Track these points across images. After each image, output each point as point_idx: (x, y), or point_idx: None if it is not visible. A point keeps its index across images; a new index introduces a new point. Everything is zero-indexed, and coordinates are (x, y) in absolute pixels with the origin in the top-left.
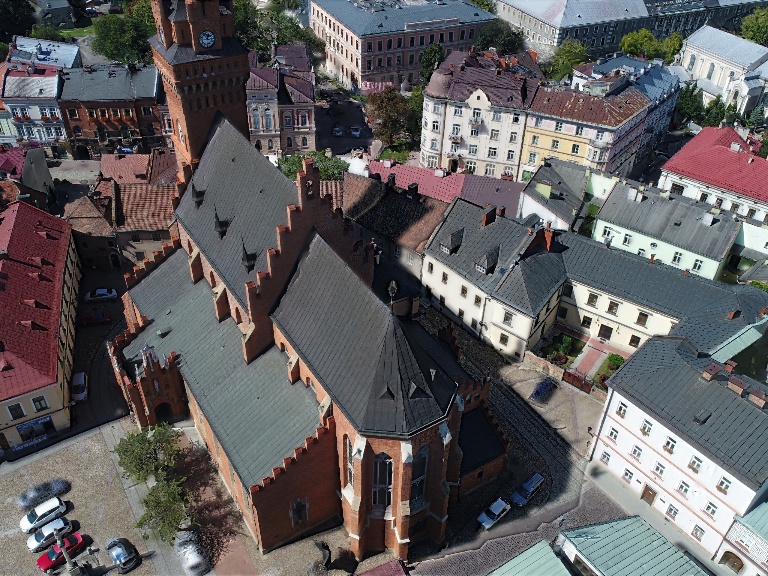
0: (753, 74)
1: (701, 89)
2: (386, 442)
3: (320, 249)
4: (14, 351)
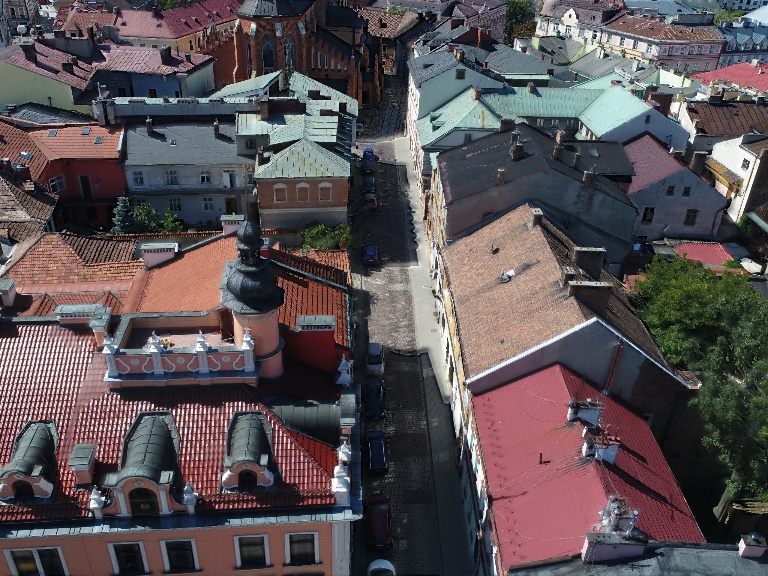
0: None
1: None
2: (247, 23)
3: None
4: (167, 22)
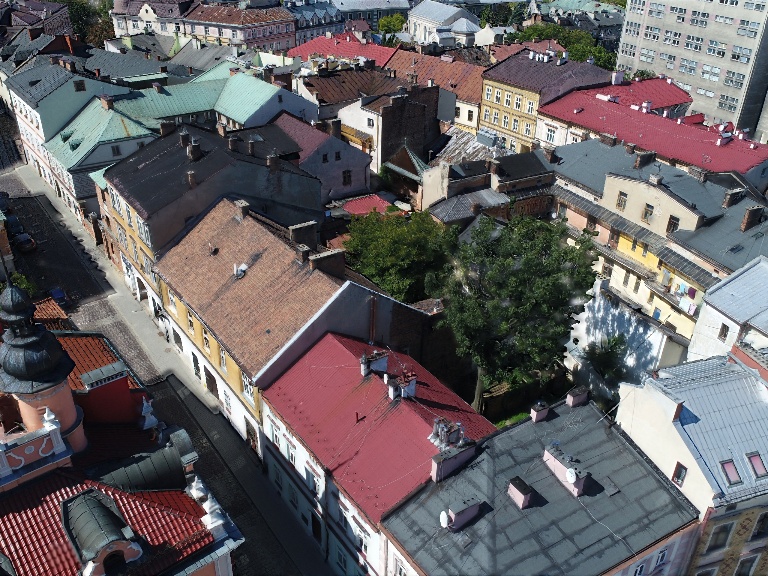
0: (445, 28)
1: (397, 38)
2: None
3: None
4: None
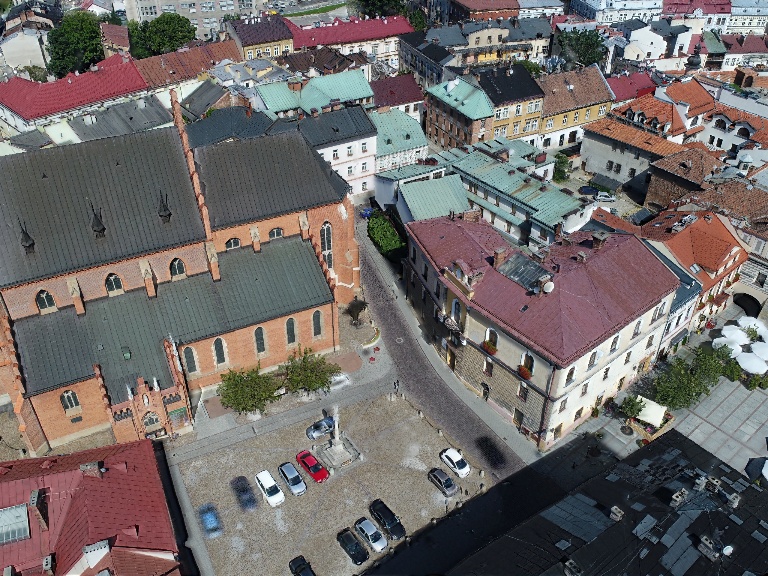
0: None
1: None
2: None
3: (208, 153)
4: None
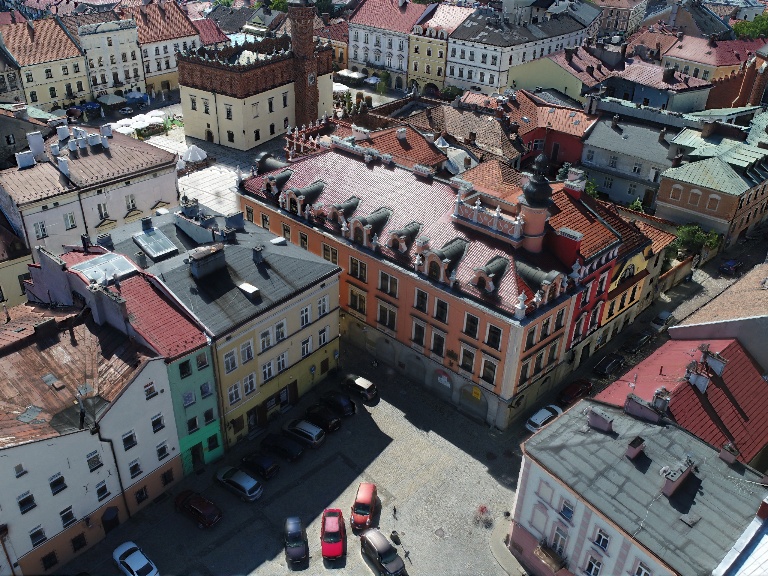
0: None
1: None
2: None
3: None
4: (718, 51)
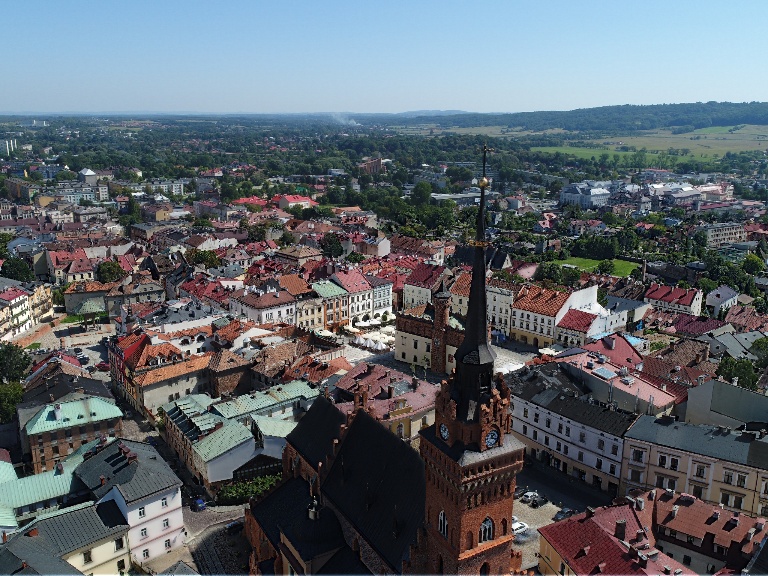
0: None
1: None
2: None
3: None
4: None
